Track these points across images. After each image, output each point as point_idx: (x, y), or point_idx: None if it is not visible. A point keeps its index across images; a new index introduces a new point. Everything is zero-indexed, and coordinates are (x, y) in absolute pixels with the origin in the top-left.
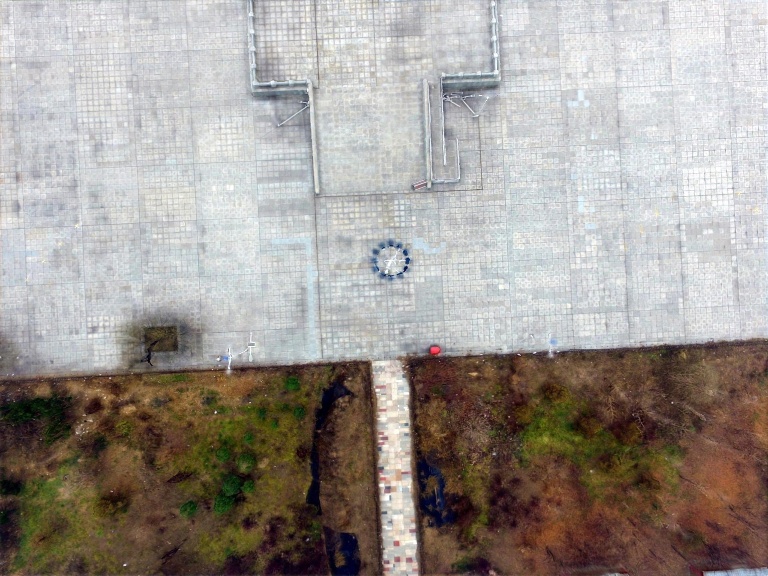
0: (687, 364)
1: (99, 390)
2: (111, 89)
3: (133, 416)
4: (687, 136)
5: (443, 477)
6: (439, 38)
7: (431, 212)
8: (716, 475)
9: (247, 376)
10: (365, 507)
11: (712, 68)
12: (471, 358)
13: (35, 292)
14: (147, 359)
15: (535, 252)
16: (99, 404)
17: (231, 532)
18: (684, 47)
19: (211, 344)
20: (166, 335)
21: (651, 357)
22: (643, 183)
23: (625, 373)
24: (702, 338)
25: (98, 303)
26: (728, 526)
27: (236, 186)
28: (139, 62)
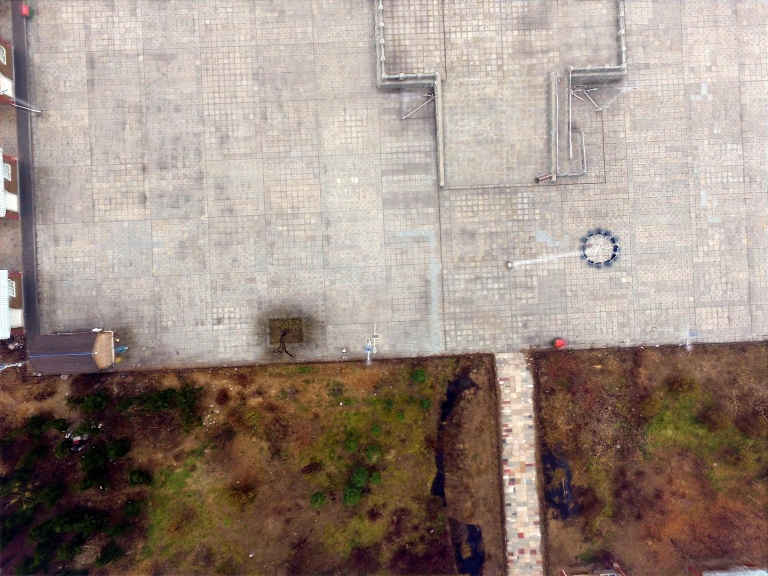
0: None
1: (226, 381)
2: (237, 81)
3: (259, 407)
4: None
5: (570, 469)
6: (566, 31)
7: (554, 205)
8: None
9: (372, 368)
10: (489, 499)
11: None
12: (594, 351)
13: (161, 283)
14: (280, 350)
15: (658, 245)
16: (227, 395)
17: (356, 523)
18: None
19: (335, 336)
20: (290, 327)
21: None
22: (766, 177)
23: (749, 366)
24: None
25: (223, 294)
26: None
27: (360, 178)
28: (265, 55)
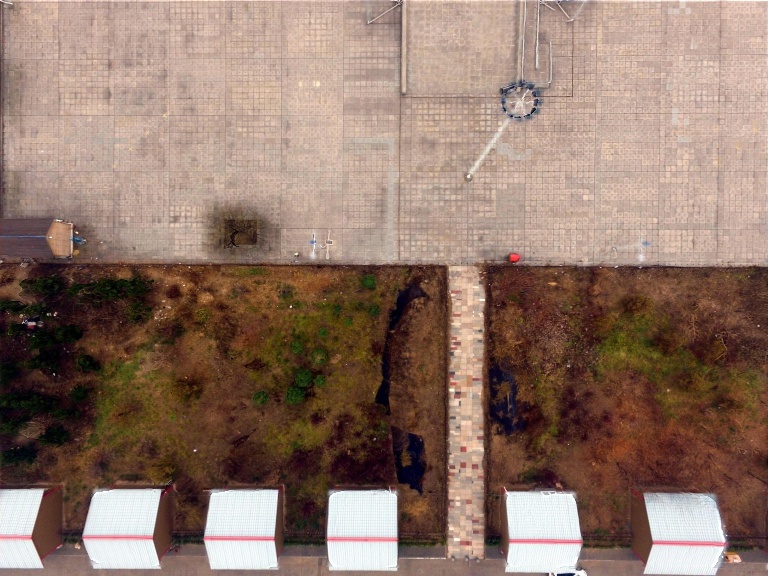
0: None
1: (179, 277)
2: None
3: (210, 305)
4: None
5: (516, 384)
6: None
7: None
8: None
9: (323, 273)
10: (434, 411)
11: None
12: (550, 268)
13: (121, 179)
14: (230, 245)
15: (623, 163)
16: (178, 291)
17: (300, 426)
18: None
19: (289, 240)
20: (245, 229)
21: (739, 278)
22: (742, 97)
23: (711, 292)
24: None
25: (181, 193)
26: None
27: (322, 83)
28: None
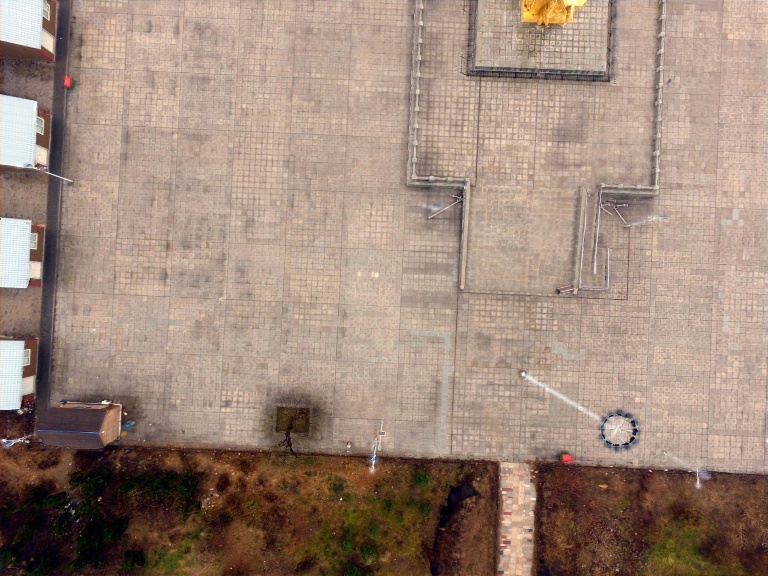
0: None
1: (228, 465)
2: (268, 167)
3: (259, 495)
4: None
5: None
6: (600, 147)
7: (573, 318)
8: None
9: (375, 465)
10: None
11: None
12: (601, 469)
13: (174, 361)
14: (285, 444)
15: (675, 368)
16: (228, 480)
17: None
18: None
19: (342, 429)
20: (297, 415)
21: None
22: None
23: (758, 501)
24: None
25: (234, 377)
26: None
27: (381, 274)
28: (297, 143)
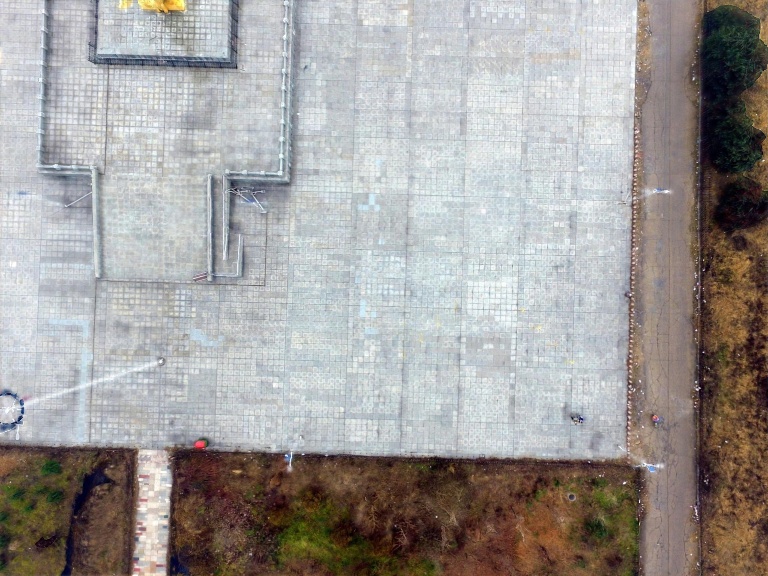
0: (450, 481)
1: None
2: None
3: None
4: (475, 249)
5: (192, 575)
6: (229, 133)
7: (211, 304)
8: None
9: (11, 455)
10: None
11: (506, 183)
12: (238, 454)
13: None
14: None
15: (312, 353)
16: None
17: None
18: (479, 159)
19: None
20: None
21: (420, 468)
22: (427, 292)
23: (390, 483)
24: (474, 453)
25: None
26: None
27: (19, 263)
28: None
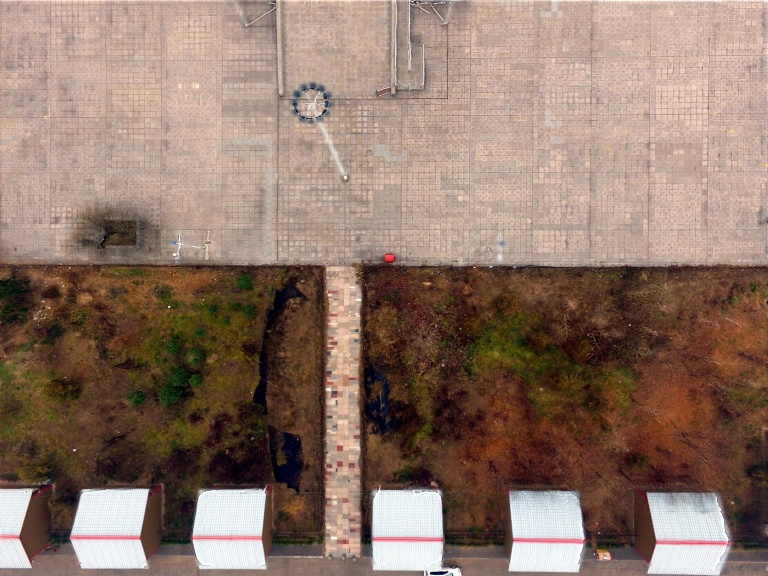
0: None
1: (58, 278)
2: None
3: (90, 306)
4: (663, 52)
5: (389, 383)
6: None
7: (394, 119)
8: (671, 402)
9: (202, 273)
10: (311, 410)
11: None
12: (426, 268)
13: (3, 180)
14: None
15: (497, 165)
16: (57, 291)
17: (178, 426)
18: None
19: (169, 240)
20: (126, 230)
21: (611, 278)
22: (614, 99)
23: (582, 292)
24: (666, 261)
25: (62, 194)
26: (680, 454)
27: (201, 85)
28: None
